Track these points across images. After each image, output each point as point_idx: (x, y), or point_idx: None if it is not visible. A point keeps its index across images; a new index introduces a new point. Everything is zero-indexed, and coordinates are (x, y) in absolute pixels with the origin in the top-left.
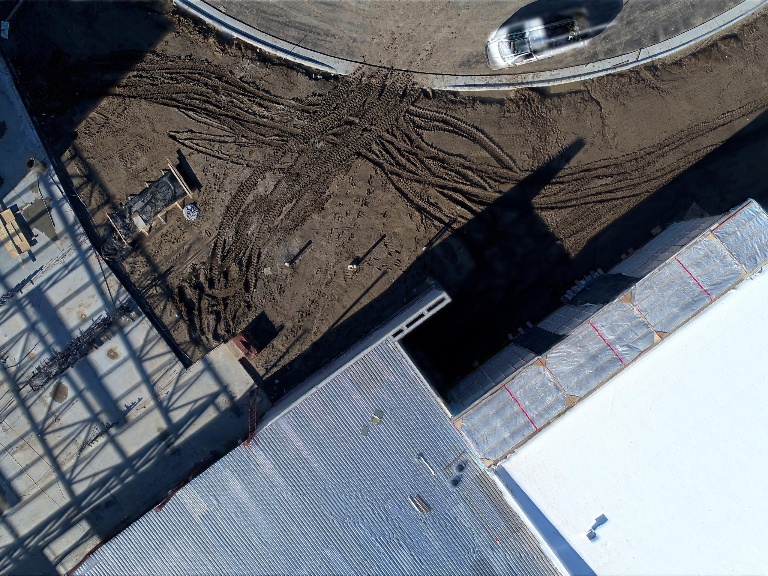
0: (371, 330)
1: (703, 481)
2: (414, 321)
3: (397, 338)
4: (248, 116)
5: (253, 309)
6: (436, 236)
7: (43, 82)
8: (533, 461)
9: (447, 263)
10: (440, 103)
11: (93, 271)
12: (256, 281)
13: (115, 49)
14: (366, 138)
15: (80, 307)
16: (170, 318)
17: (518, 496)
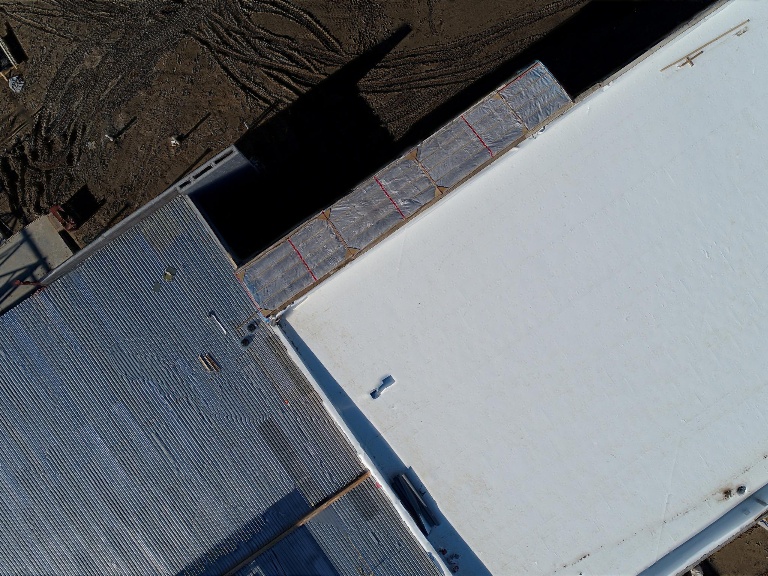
0: None
1: (492, 345)
2: (201, 172)
3: (184, 189)
4: None
5: (76, 182)
6: (261, 116)
7: None
8: (320, 319)
9: (271, 143)
10: None
11: None
12: (80, 155)
13: None
14: (194, 17)
15: None
16: None
17: (303, 353)
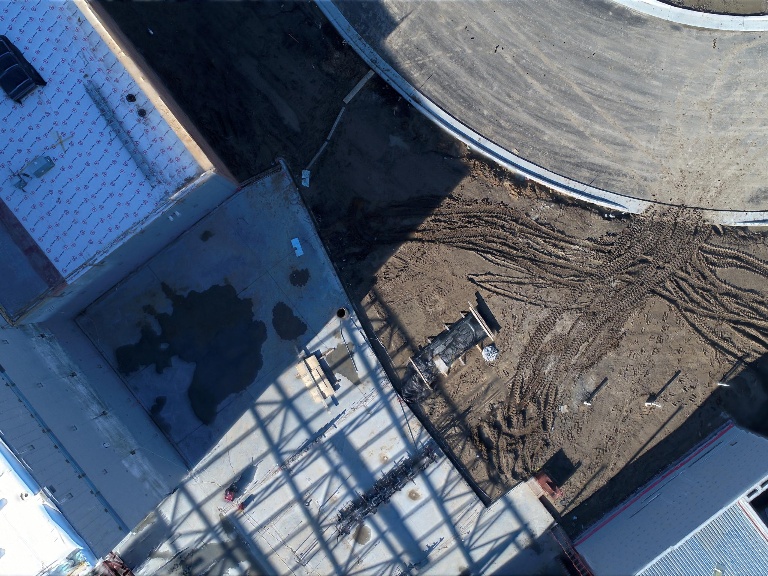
0: (668, 465)
1: None
2: None
3: (752, 498)
4: (544, 257)
5: (551, 447)
6: (730, 371)
7: (343, 228)
8: None
9: (741, 397)
10: (731, 239)
11: (395, 414)
12: (554, 419)
13: (413, 194)
14: (659, 276)
15: (382, 449)
16: (469, 457)
17: None
